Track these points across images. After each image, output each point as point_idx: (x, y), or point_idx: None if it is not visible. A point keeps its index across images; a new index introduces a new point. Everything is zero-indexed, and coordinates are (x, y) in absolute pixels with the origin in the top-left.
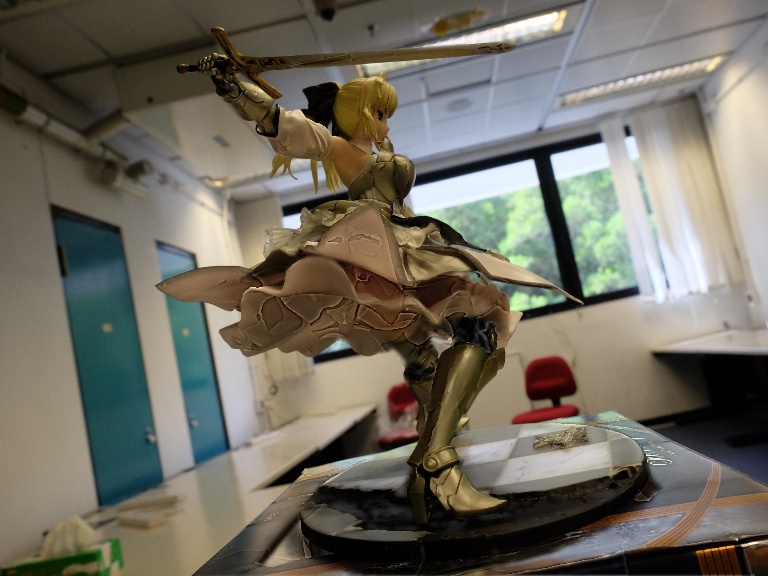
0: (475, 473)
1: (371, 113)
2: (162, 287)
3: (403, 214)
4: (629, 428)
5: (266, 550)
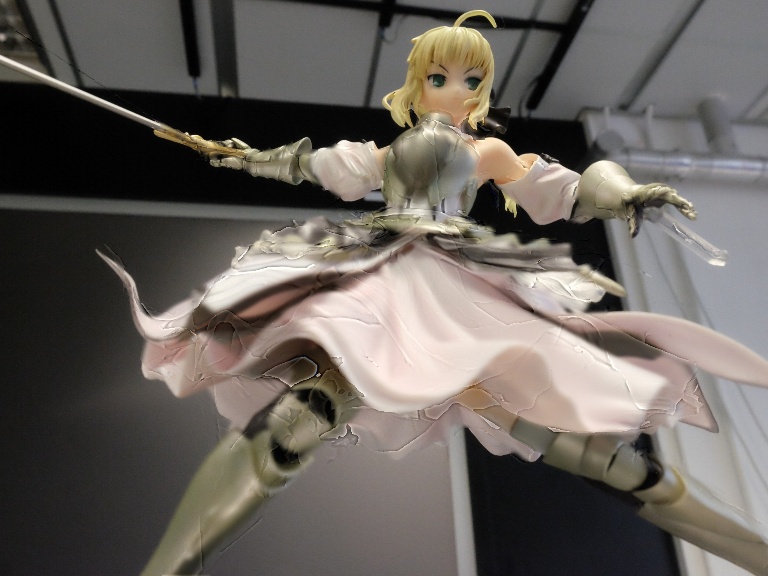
0: None
1: (411, 87)
2: (234, 393)
3: (595, 196)
4: None
5: None
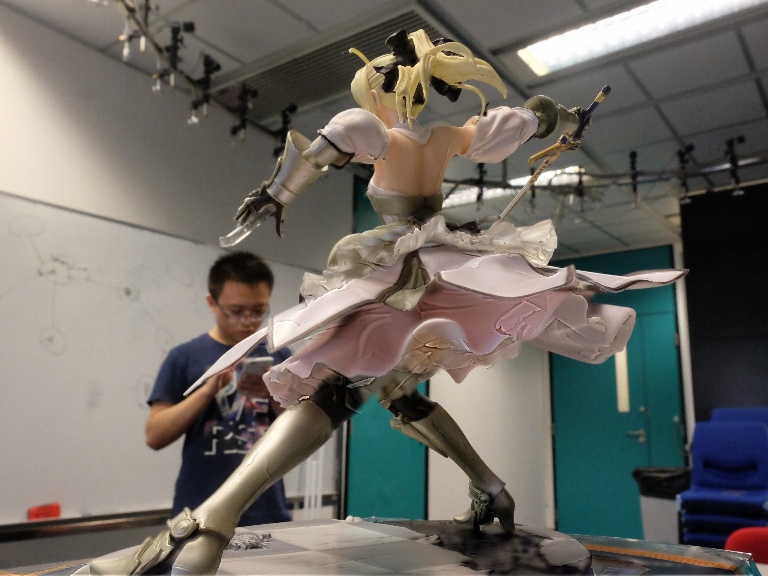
0: (375, 550)
1: None
2: None
3: None
4: (85, 562)
5: (639, 575)
